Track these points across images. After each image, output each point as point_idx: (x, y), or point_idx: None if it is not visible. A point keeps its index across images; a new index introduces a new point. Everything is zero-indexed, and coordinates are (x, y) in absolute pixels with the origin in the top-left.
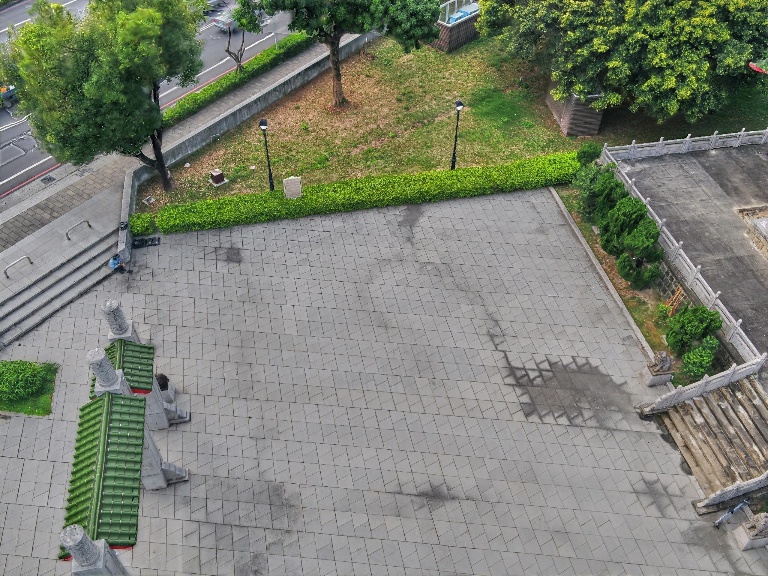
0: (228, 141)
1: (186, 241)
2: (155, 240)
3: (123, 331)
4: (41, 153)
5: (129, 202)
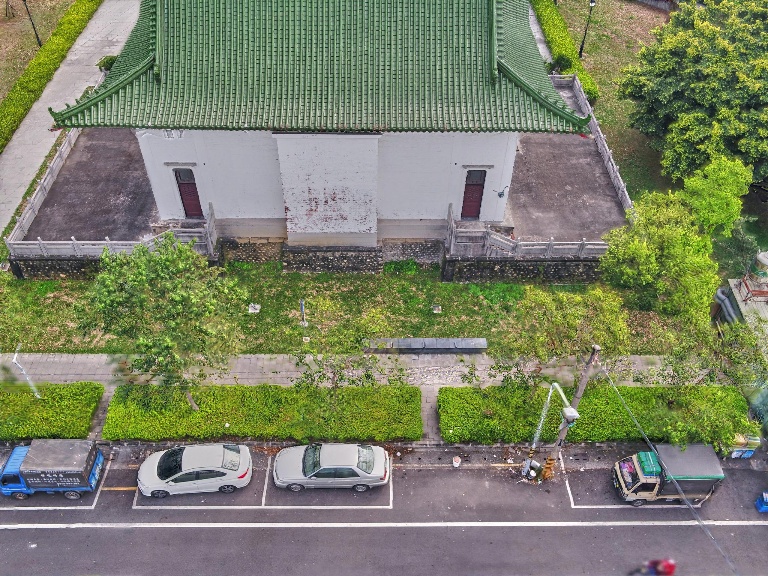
0: None
1: None
2: None
3: None
4: None
5: None
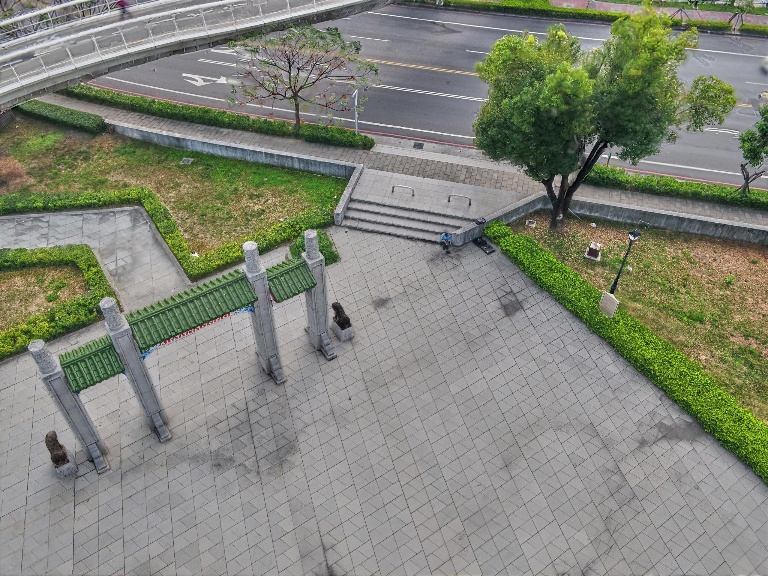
0: (651, 235)
1: (505, 269)
2: (490, 249)
3: (310, 257)
4: (473, 130)
5: (509, 211)
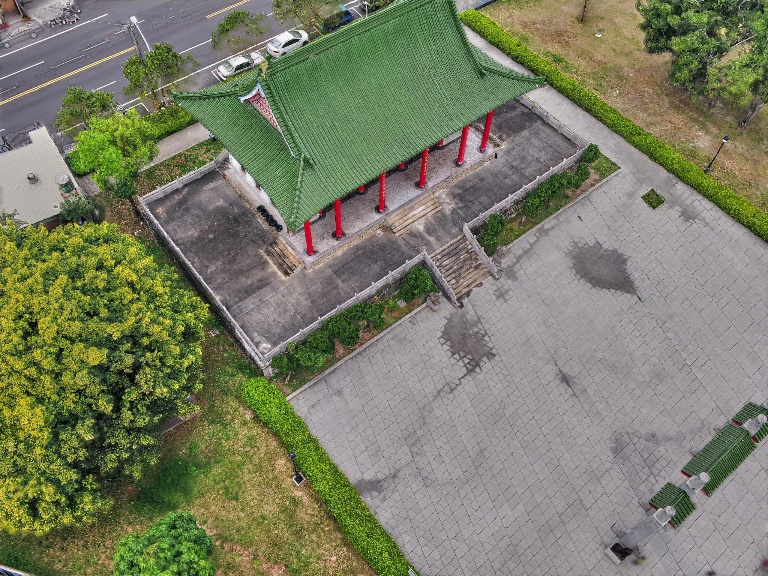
0: None
1: None
2: None
3: None
4: None
5: None
